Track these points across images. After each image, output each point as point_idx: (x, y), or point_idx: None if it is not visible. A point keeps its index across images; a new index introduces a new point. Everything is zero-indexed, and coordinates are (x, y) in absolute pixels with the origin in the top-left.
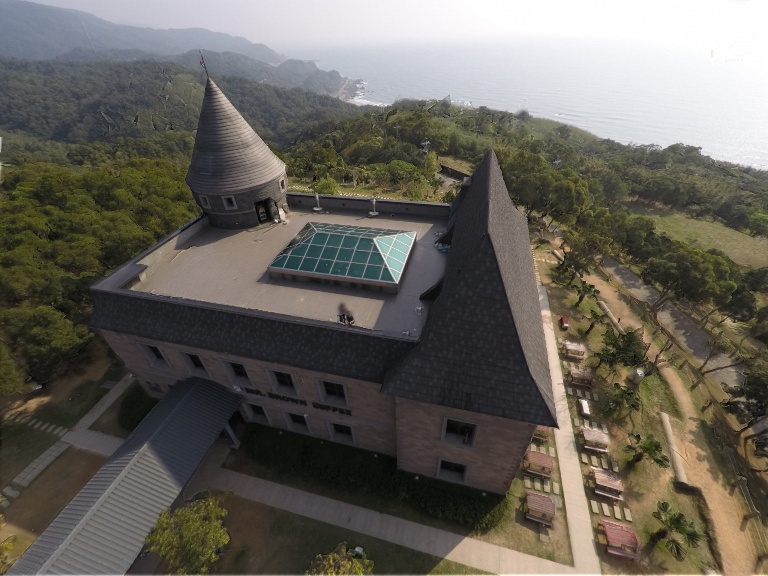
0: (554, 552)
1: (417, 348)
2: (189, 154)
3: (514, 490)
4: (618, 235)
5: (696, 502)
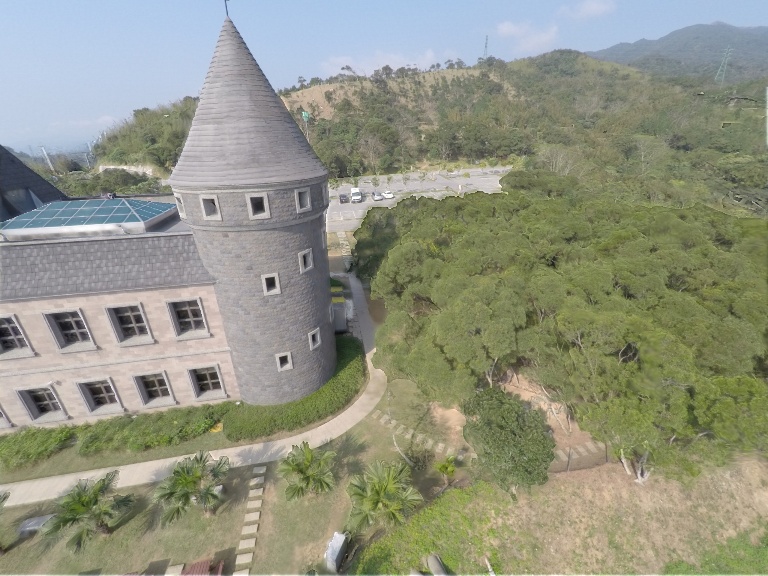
0: None
1: None
2: None
3: None
4: None
5: None
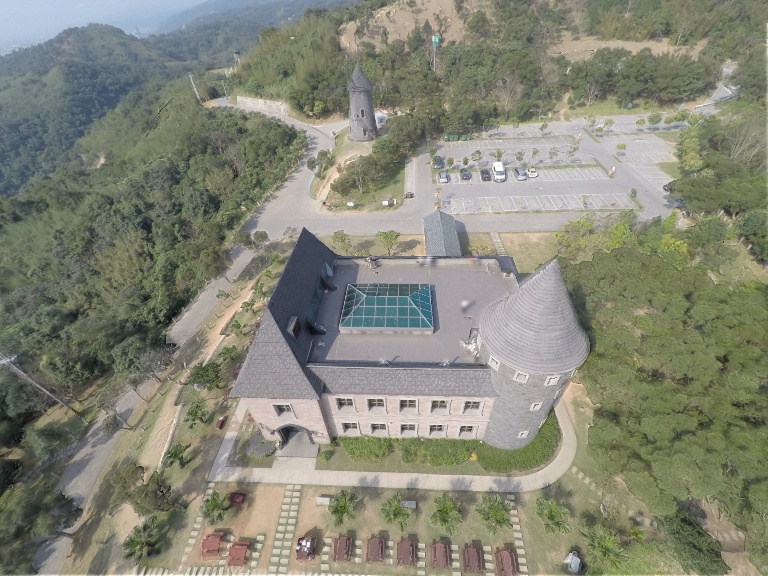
0: None
1: (336, 255)
2: None
3: None
4: None
5: (225, 331)
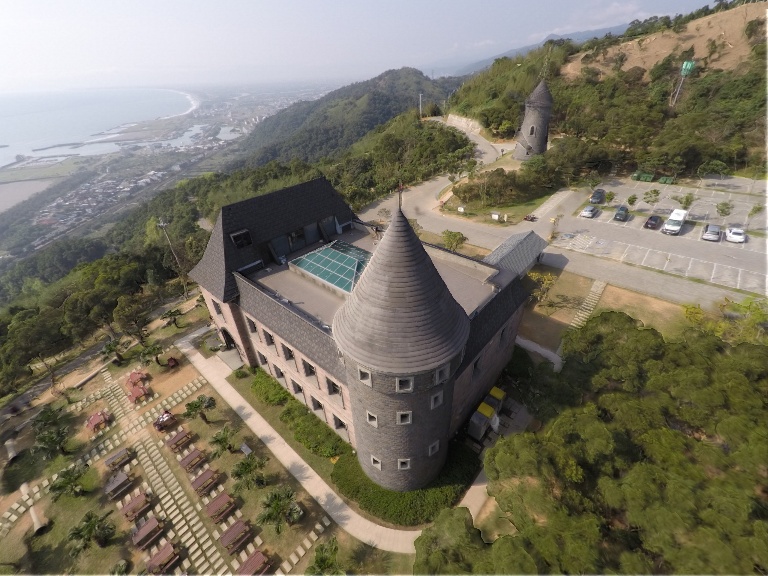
0: None
1: None
2: None
3: None
4: (50, 339)
5: None
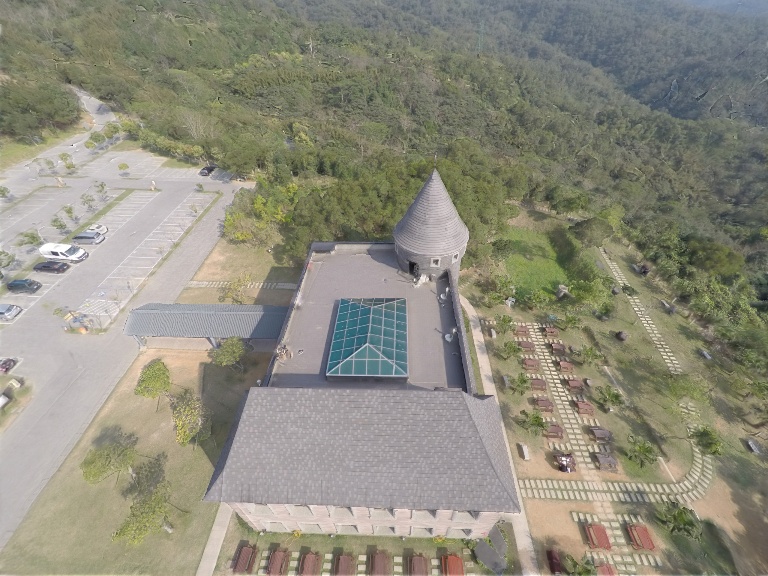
0: (220, 571)
1: None
2: (709, 152)
3: (262, 541)
4: None
5: None
